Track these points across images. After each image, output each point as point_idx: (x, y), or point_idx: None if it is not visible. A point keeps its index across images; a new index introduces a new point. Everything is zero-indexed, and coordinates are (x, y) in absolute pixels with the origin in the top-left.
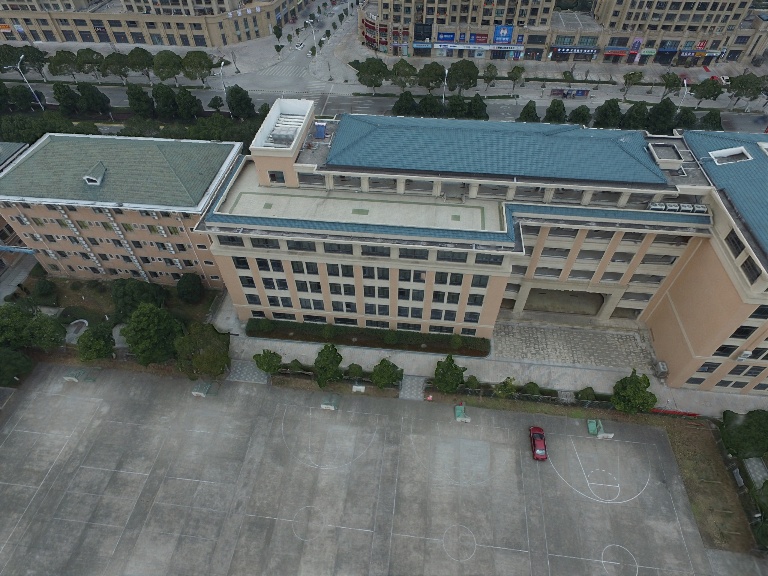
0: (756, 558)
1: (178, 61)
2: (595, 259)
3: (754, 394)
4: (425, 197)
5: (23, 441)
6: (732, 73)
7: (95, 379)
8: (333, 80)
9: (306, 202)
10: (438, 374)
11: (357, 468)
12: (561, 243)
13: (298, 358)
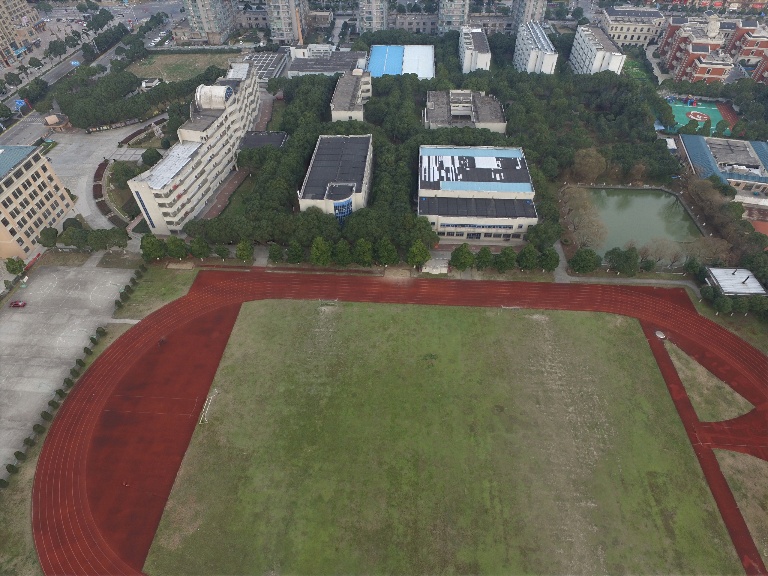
0: (92, 256)
1: None
2: None
3: None
4: None
5: None
6: None
7: None
8: None
9: None
10: None
11: None
12: None
13: None
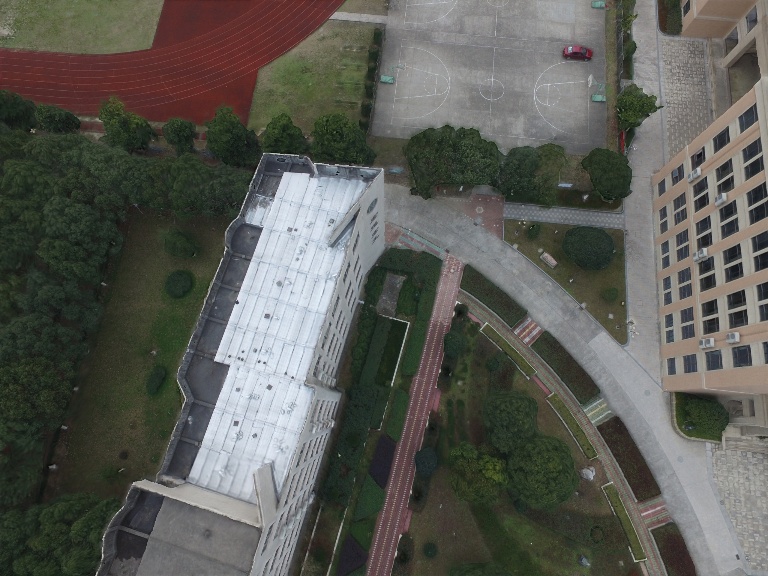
0: None
1: None
2: None
3: (656, 252)
4: None
5: None
6: None
7: None
8: None
9: None
10: None
11: None
12: None
13: None
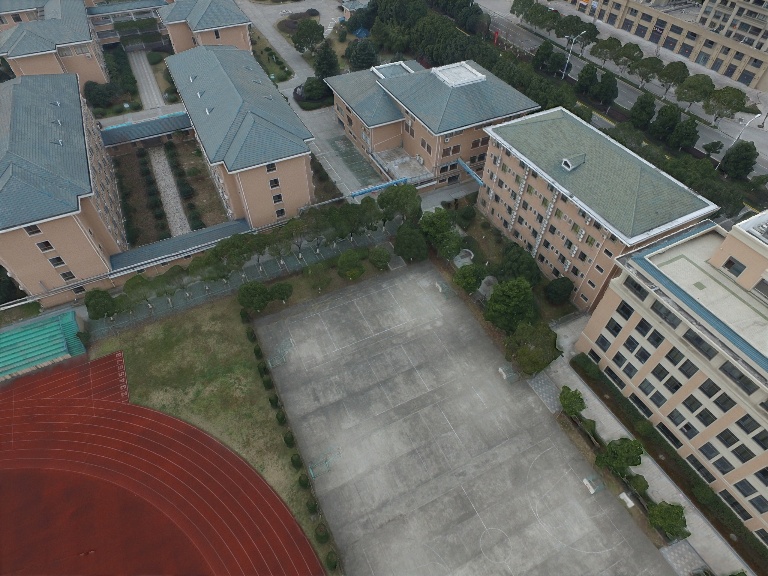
0: None
1: (709, 90)
2: None
3: None
4: None
5: (387, 300)
6: None
7: (449, 298)
8: None
9: (744, 311)
10: None
11: (567, 556)
12: None
13: (595, 421)
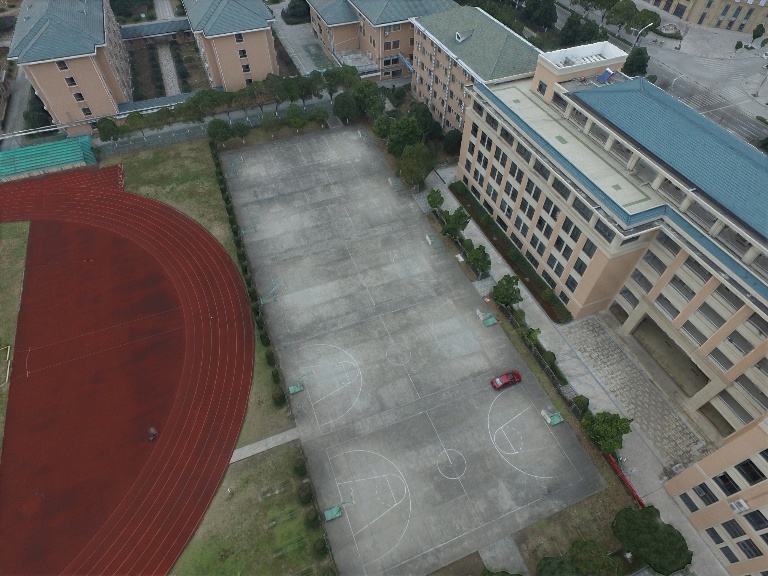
0: None
1: (631, 13)
2: (715, 325)
3: None
4: (619, 164)
5: (322, 145)
6: None
7: (369, 146)
8: (757, 97)
9: (540, 114)
10: (501, 282)
11: (406, 281)
12: (691, 280)
13: None
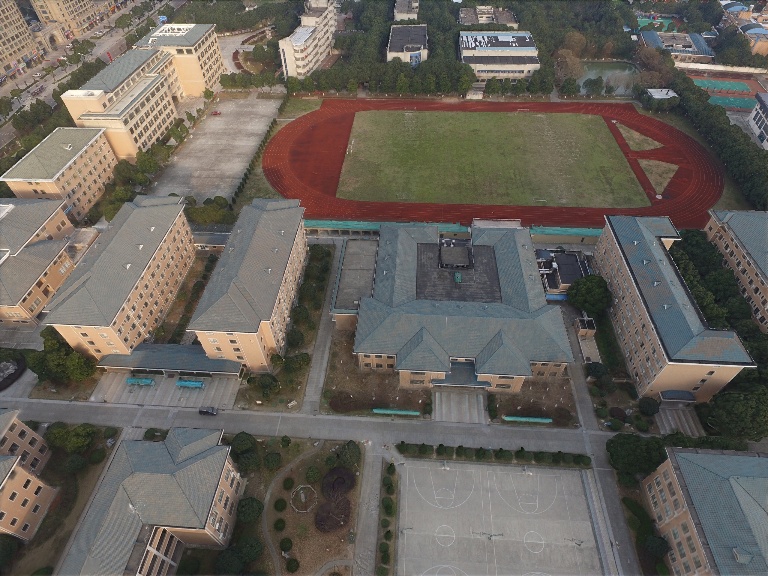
0: (251, 94)
1: None
2: None
3: None
4: None
5: None
6: (57, 56)
7: (155, 190)
8: None
9: None
10: None
11: None
12: None
13: None
